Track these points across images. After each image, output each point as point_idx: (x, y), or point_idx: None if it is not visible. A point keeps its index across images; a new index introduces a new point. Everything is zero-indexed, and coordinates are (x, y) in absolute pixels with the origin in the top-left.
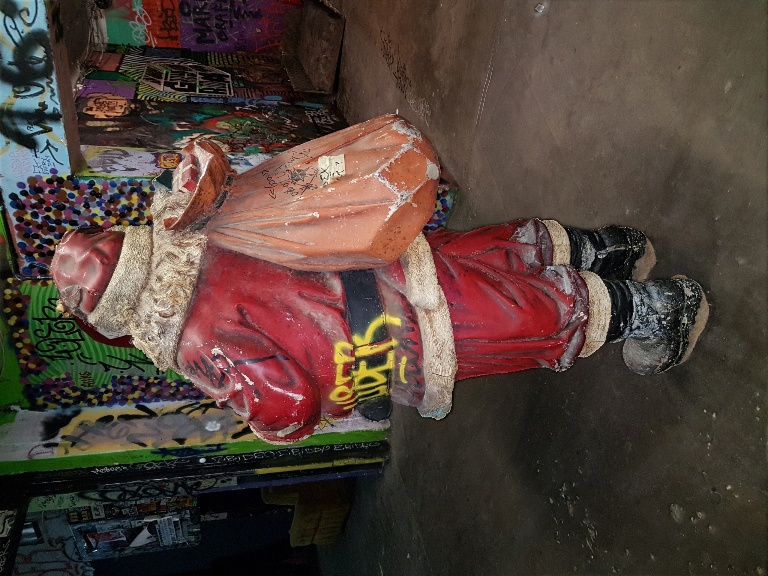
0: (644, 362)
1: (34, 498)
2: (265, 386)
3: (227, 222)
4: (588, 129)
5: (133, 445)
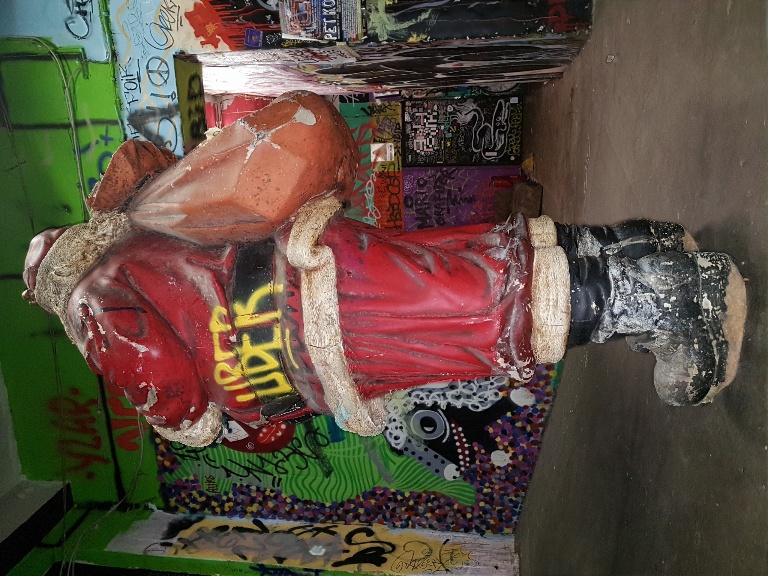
0: (669, 381)
1: None
2: (113, 334)
3: (141, 199)
4: (645, 147)
5: (235, 556)
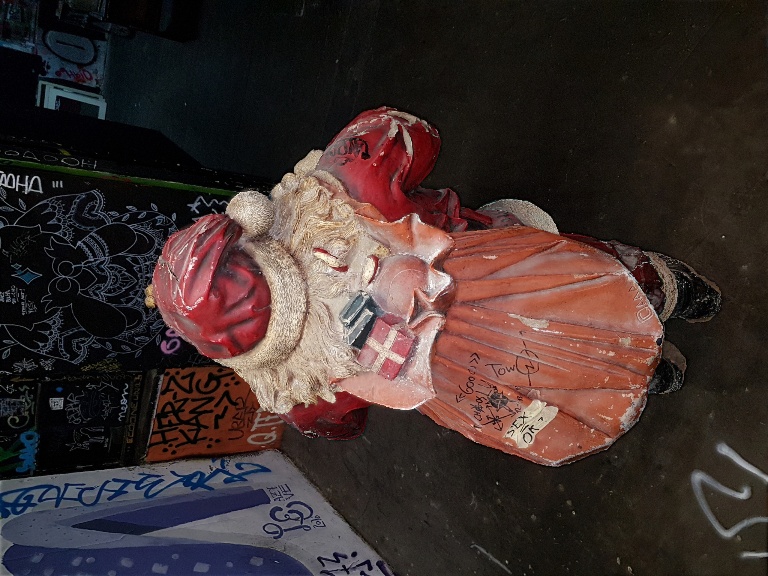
0: None
1: None
2: None
3: None
4: None
5: None
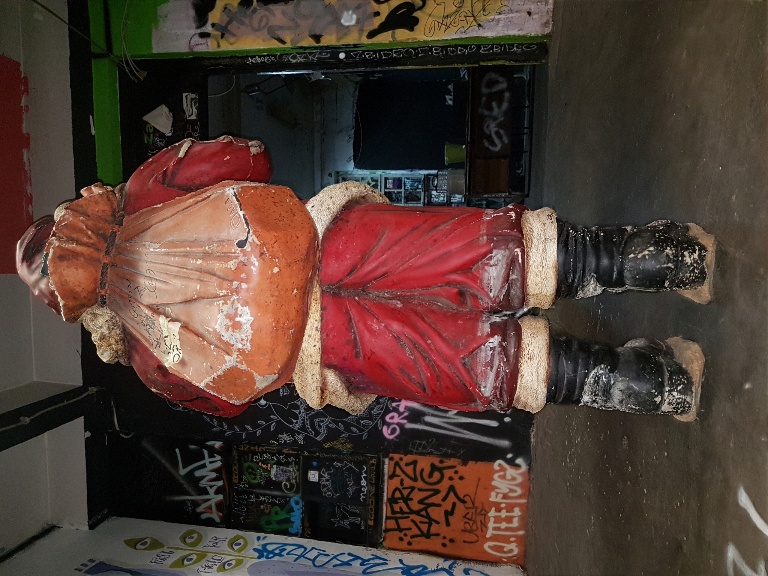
0: None
1: (210, 76)
2: None
3: None
4: None
5: (273, 41)
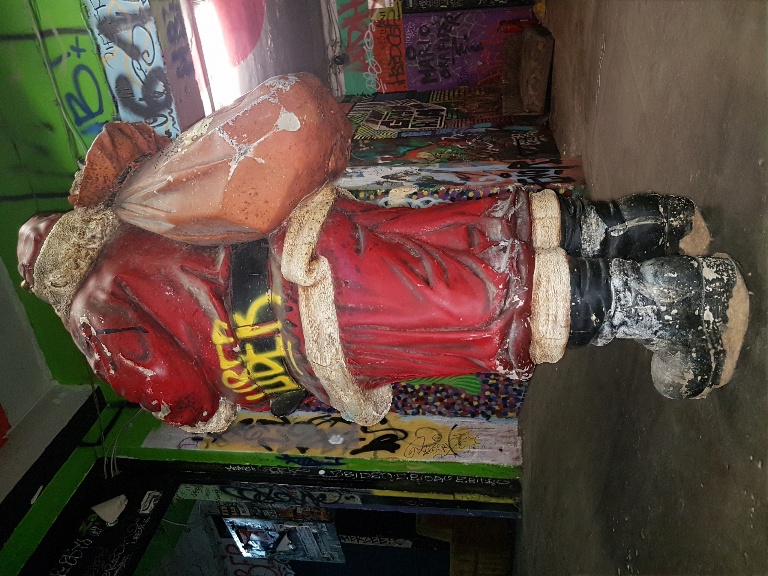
0: (665, 379)
1: (181, 484)
2: (118, 357)
3: (125, 196)
4: (663, 80)
5: (261, 448)
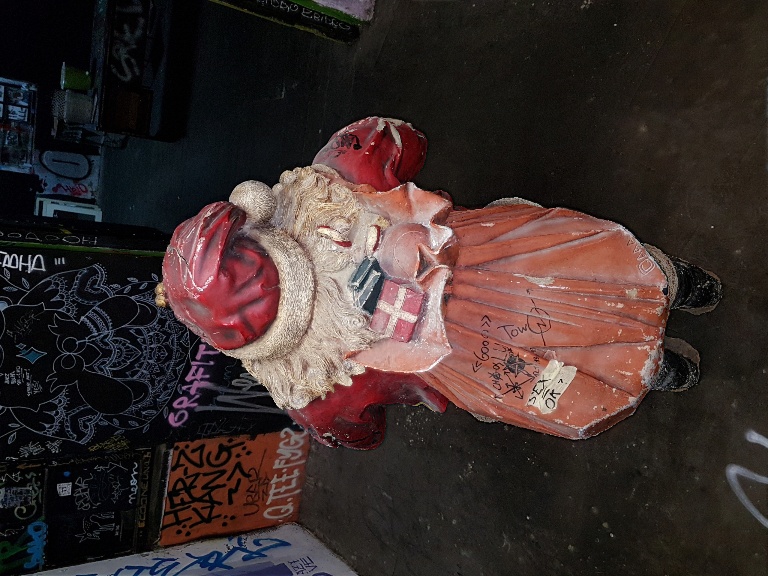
0: None
1: None
2: None
3: None
4: None
5: None
